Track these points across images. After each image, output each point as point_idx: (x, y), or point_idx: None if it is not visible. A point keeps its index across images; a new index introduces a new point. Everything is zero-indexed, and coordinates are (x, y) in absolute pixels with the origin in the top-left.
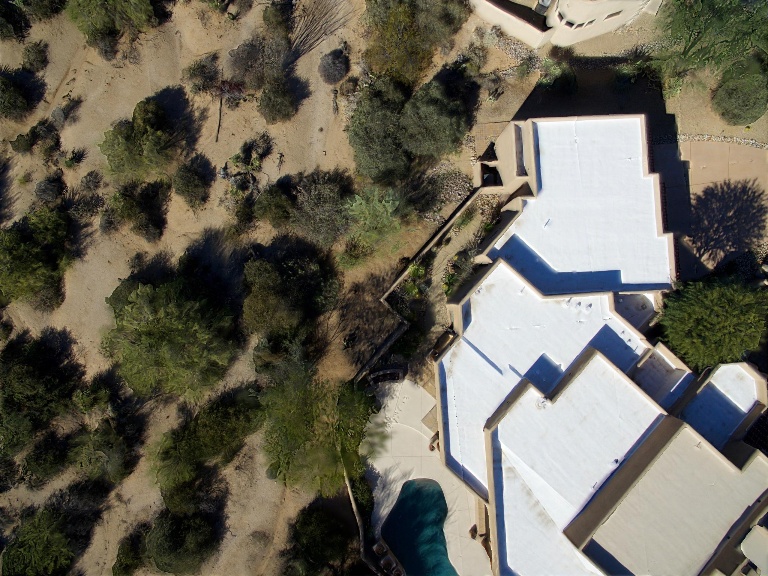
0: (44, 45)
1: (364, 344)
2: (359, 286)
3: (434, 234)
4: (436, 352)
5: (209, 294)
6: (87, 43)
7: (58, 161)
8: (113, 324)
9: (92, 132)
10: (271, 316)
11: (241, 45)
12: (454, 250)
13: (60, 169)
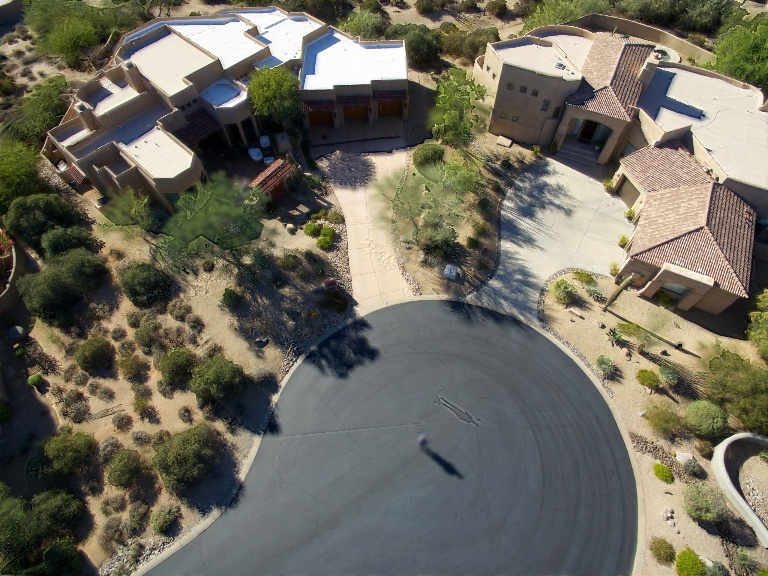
0: None
1: None
2: None
3: None
4: None
5: None
6: None
7: None
8: None
9: None
10: None
11: None
12: None
13: None
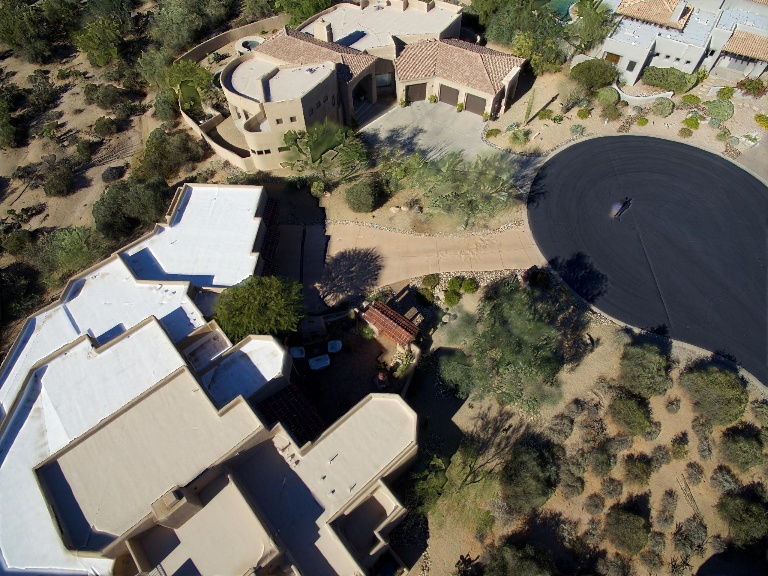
0: None
1: None
2: None
3: None
4: None
5: None
6: None
7: None
8: None
9: None
10: None
11: None
12: None
13: None
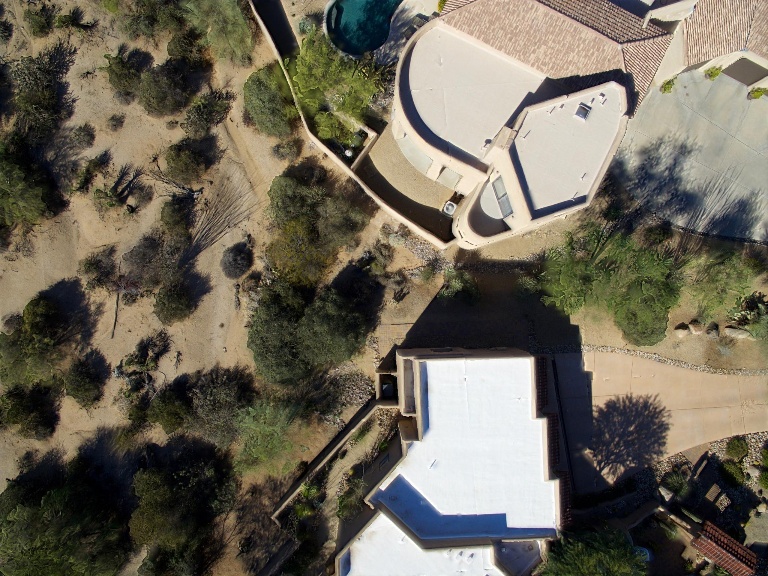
0: None
1: (258, 551)
2: (256, 488)
3: (333, 439)
4: (325, 575)
5: (98, 502)
6: None
7: None
8: None
9: None
10: (156, 537)
11: (136, 247)
12: (350, 462)
13: None
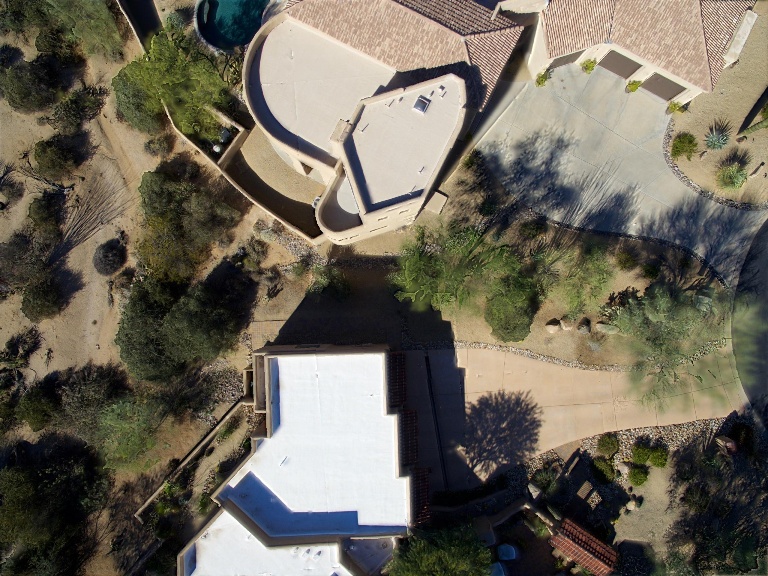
0: None
1: (129, 549)
2: (129, 486)
3: (205, 436)
4: None
5: None
6: None
7: None
8: None
9: None
10: (16, 534)
11: (1, 244)
12: (217, 460)
13: None
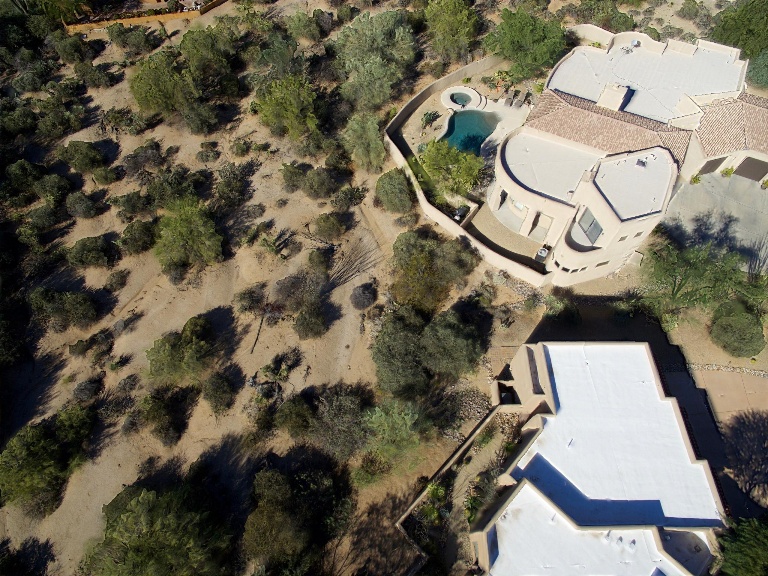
0: (127, 272)
1: None
2: (373, 507)
3: (454, 452)
4: None
5: (212, 507)
6: (162, 272)
7: (105, 364)
8: (100, 538)
9: (143, 341)
10: (274, 537)
11: (288, 277)
12: (475, 470)
13: (104, 372)
